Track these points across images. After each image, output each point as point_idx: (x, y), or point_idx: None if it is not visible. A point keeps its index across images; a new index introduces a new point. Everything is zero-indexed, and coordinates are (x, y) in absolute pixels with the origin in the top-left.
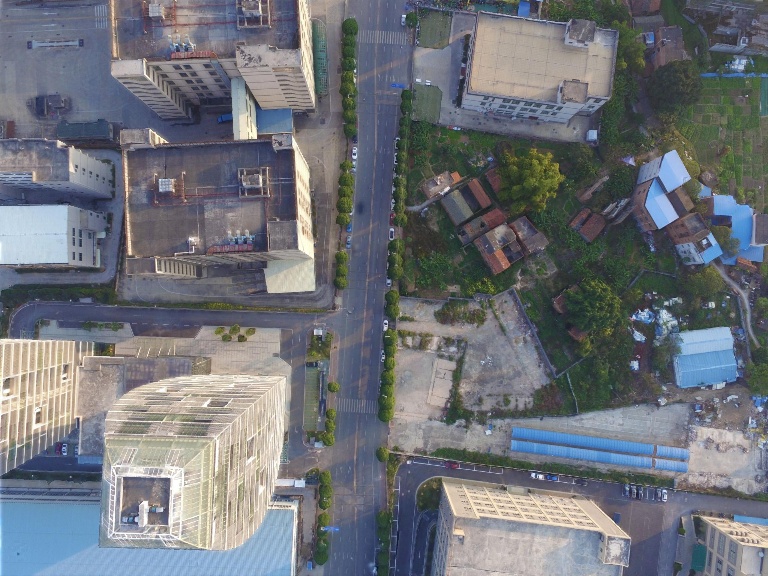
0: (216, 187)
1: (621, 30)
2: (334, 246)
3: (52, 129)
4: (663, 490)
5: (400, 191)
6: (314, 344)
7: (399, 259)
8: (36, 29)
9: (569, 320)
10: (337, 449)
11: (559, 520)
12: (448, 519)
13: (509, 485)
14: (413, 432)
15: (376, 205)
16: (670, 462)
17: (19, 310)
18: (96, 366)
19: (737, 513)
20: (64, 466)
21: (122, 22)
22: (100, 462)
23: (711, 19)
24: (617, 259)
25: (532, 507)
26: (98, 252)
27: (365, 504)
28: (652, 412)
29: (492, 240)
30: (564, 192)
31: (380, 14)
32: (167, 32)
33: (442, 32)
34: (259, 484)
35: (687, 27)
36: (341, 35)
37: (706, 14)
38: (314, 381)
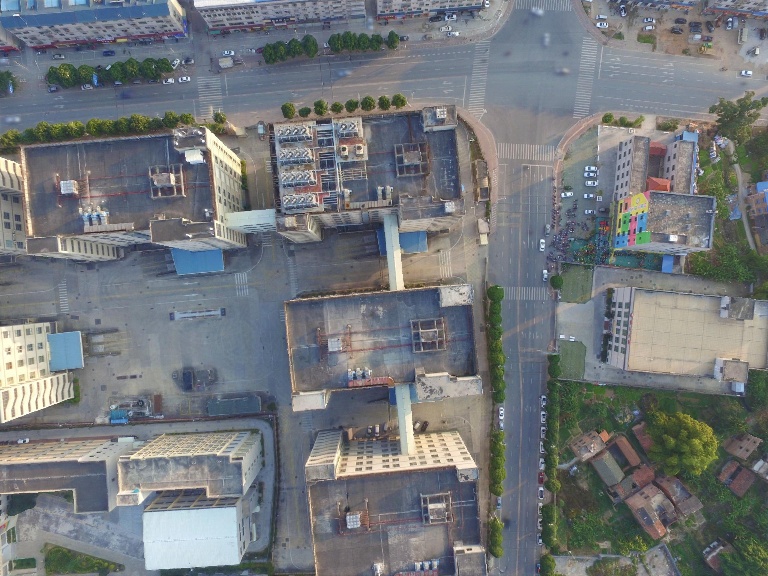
0: (399, 513)
1: None
2: (484, 506)
3: (199, 401)
4: None
5: (555, 463)
6: None
7: (556, 530)
8: (177, 300)
9: None
10: None
11: None
12: None
13: None
14: None
15: (524, 464)
16: None
17: None
18: None
19: None
20: None
21: (297, 350)
22: None
23: None
24: None
25: None
26: (254, 527)
27: None
28: None
29: (651, 513)
30: None
31: (521, 270)
32: (342, 358)
33: (584, 286)
34: None
35: None
36: (483, 293)
37: None
38: None
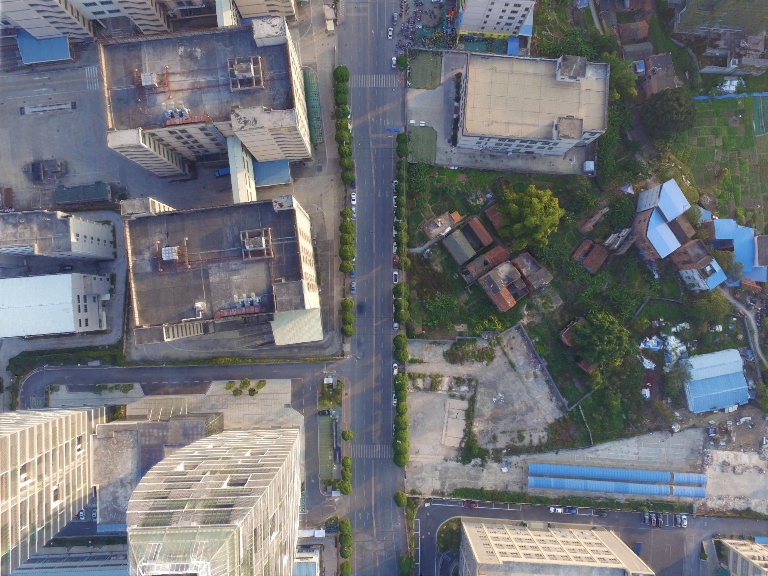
0: (219, 251)
1: (611, 62)
2: (339, 293)
3: (50, 193)
4: (682, 516)
5: (402, 236)
6: (325, 392)
7: (405, 304)
8: (28, 94)
9: (578, 354)
10: (354, 496)
11: (582, 558)
12: (471, 564)
13: (528, 521)
14: (429, 474)
15: (378, 249)
16: (688, 488)
17: (28, 377)
18: (109, 433)
19: (757, 534)
20: (82, 531)
21: (115, 92)
22: (119, 530)
23: (700, 42)
24: (622, 289)
25: (553, 545)
26: (104, 314)
27: (386, 549)
28: (666, 439)
29: (497, 280)
30: (565, 224)
31: (370, 58)
32: (161, 99)
33: (433, 72)
34: (283, 556)
35: (676, 51)
36: (333, 81)
37: (694, 37)
38: (327, 429)
